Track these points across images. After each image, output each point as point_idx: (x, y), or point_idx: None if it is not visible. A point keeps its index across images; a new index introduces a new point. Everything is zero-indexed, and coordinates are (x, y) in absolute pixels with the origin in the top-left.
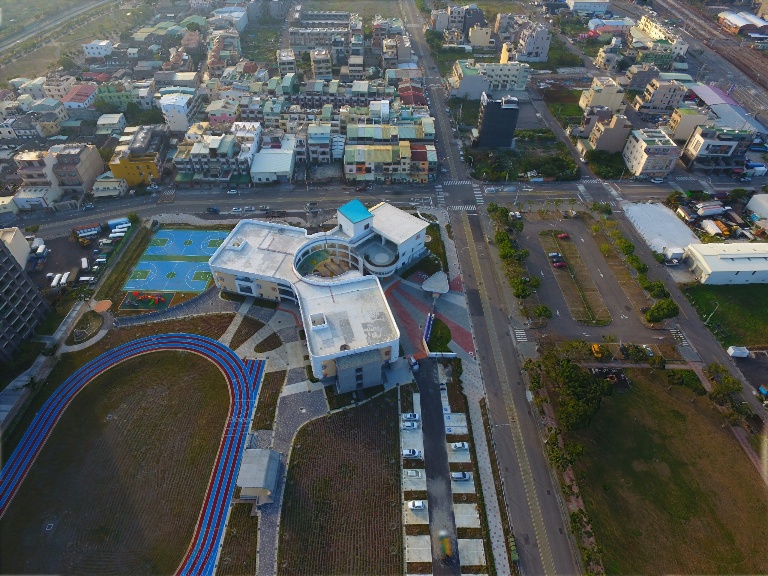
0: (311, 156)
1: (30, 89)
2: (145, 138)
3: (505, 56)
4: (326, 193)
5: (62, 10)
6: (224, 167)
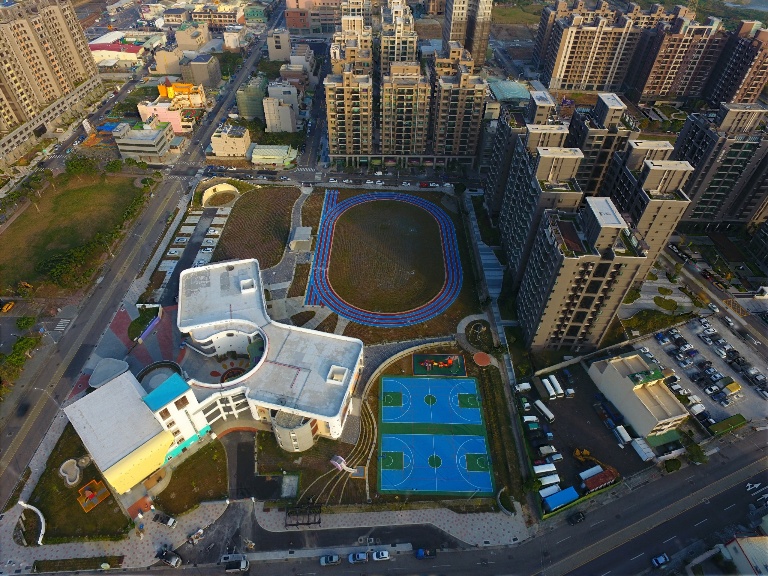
0: None
1: None
2: None
3: None
4: None
5: None
6: None
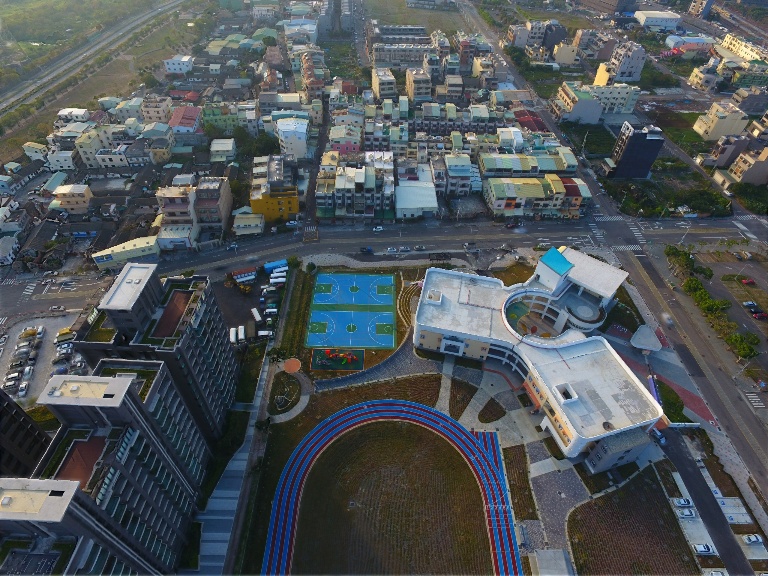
0: (449, 188)
1: (127, 110)
2: (279, 170)
3: (604, 76)
4: (477, 230)
5: (120, 20)
6: (367, 202)
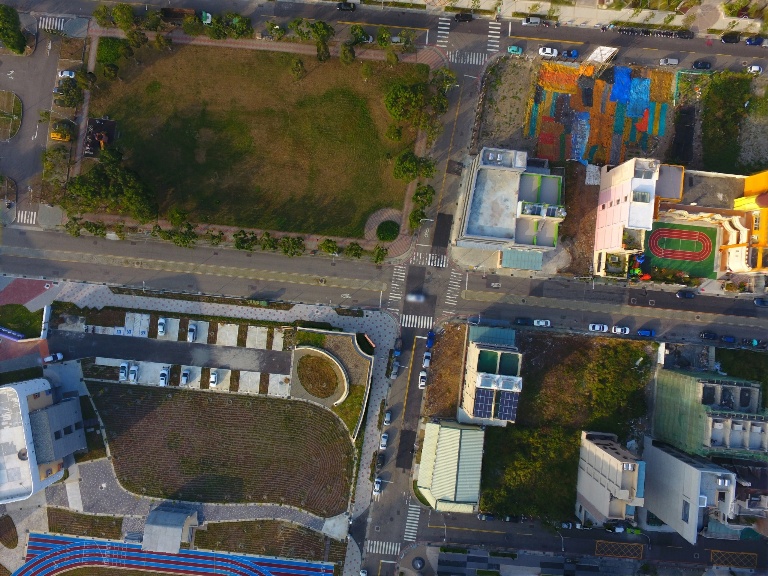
0: None
1: None
2: None
3: None
4: None
5: None
6: None
